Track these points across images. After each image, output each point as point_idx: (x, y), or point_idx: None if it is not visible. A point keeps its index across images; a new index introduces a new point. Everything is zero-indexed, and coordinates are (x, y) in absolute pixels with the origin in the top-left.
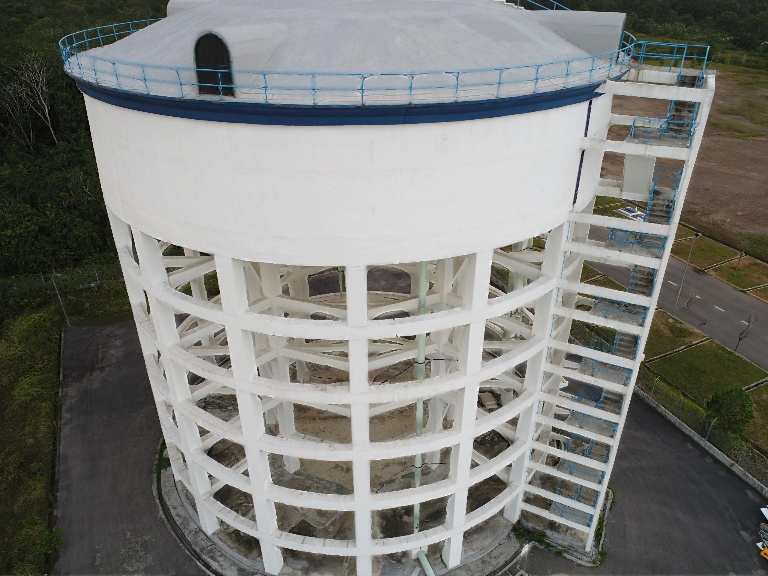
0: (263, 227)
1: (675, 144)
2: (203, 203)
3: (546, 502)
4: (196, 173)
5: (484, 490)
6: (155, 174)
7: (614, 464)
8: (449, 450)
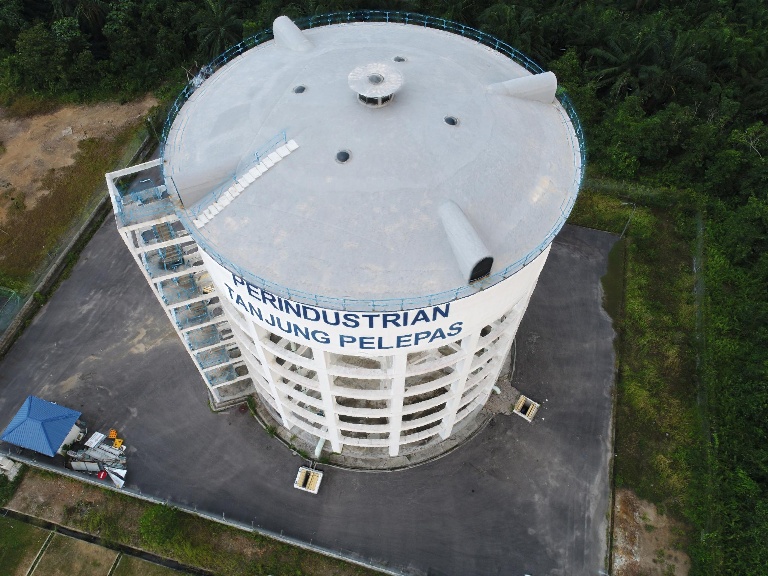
0: None
1: (131, 197)
2: None
3: (240, 367)
4: None
5: None
6: None
7: (223, 436)
8: (311, 353)
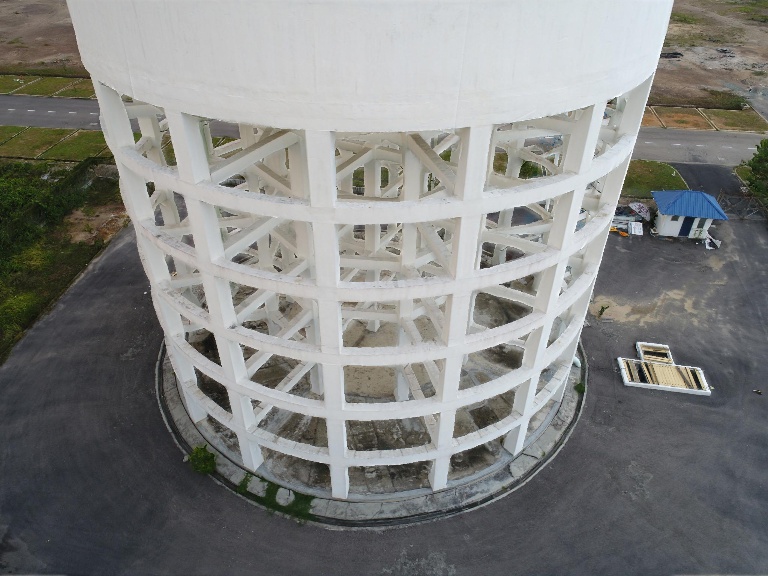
0: (639, 50)
1: None
2: (606, 42)
3: None
4: (611, 4)
5: (504, 300)
6: (558, 25)
7: None
8: None
